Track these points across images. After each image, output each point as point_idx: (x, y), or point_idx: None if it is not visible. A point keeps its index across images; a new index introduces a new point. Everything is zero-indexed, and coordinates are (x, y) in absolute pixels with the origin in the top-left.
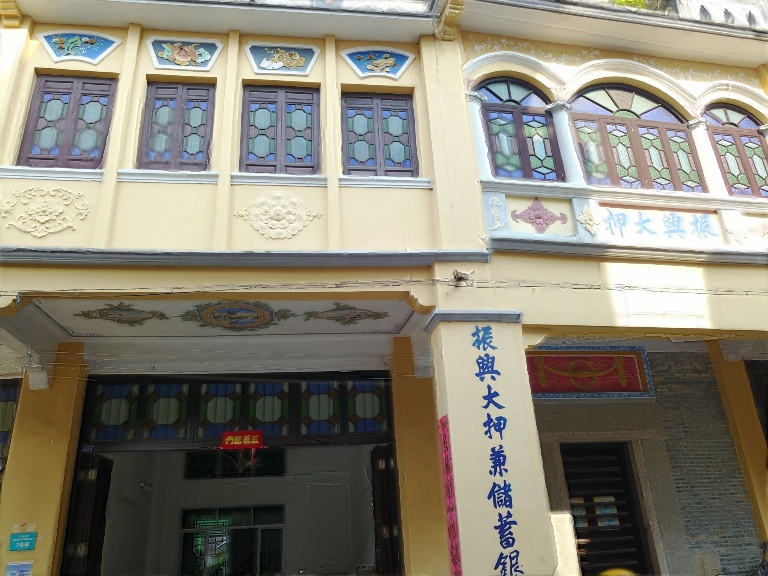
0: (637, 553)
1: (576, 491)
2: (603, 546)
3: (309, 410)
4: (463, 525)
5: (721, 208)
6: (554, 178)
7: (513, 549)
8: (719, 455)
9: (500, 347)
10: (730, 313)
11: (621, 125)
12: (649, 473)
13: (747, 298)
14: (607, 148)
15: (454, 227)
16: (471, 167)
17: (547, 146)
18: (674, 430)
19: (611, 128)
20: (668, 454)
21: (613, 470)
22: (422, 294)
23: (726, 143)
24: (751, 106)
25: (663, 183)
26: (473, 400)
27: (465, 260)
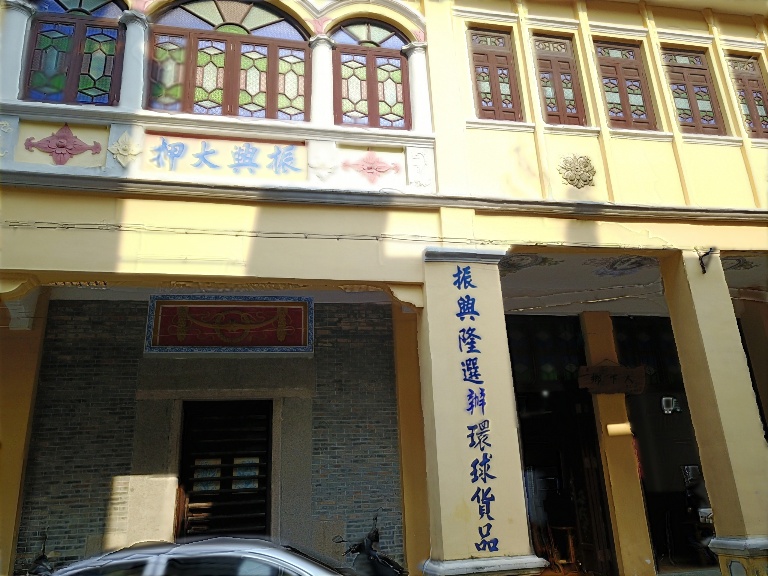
0: (264, 518)
1: (208, 452)
2: (229, 510)
3: None
4: None
5: (309, 138)
6: (104, 101)
7: None
8: (375, 415)
9: None
10: (276, 258)
11: (217, 41)
12: (284, 434)
13: (304, 242)
14: (188, 67)
15: None
16: None
17: (108, 64)
18: (327, 388)
19: (204, 44)
20: (313, 413)
21: (259, 430)
22: None
23: (355, 64)
24: (397, 22)
25: (253, 109)
26: None
27: None
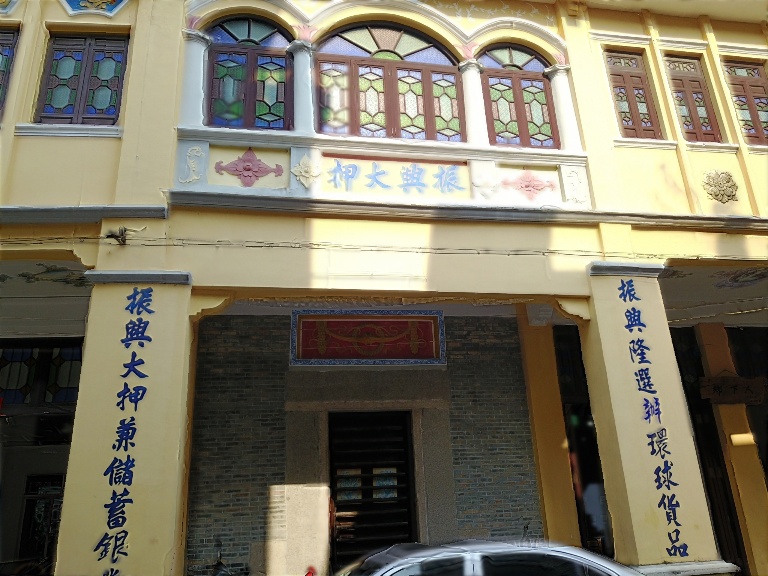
0: (408, 527)
1: (350, 462)
2: (373, 519)
3: (58, 377)
4: (67, 503)
5: (471, 158)
6: (280, 126)
7: (121, 529)
8: (509, 425)
9: (158, 311)
10: (453, 274)
11: (376, 67)
12: (425, 444)
13: (477, 257)
14: (352, 93)
15: (133, 179)
16: (169, 113)
17: (280, 90)
18: (462, 399)
19: (364, 70)
20: (451, 424)
21: (396, 440)
22: (85, 253)
23: (502, 87)
24: (538, 46)
25: (414, 131)
26: (112, 368)
27: (134, 215)
